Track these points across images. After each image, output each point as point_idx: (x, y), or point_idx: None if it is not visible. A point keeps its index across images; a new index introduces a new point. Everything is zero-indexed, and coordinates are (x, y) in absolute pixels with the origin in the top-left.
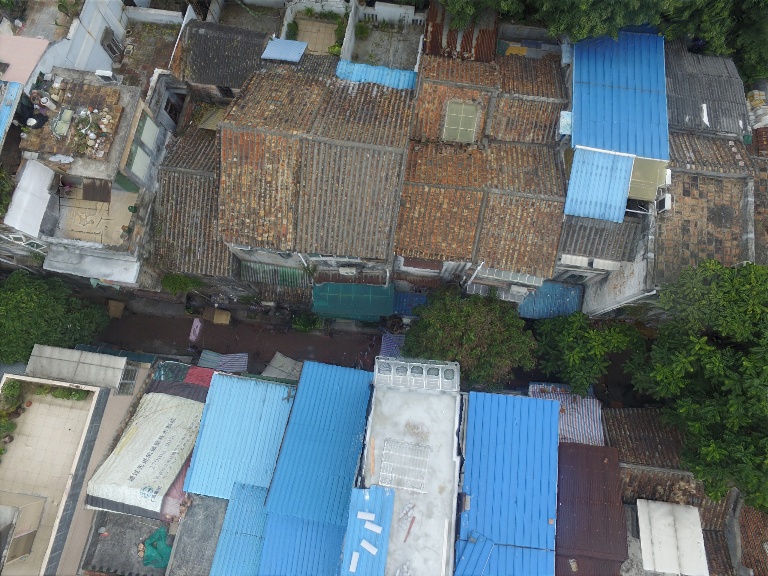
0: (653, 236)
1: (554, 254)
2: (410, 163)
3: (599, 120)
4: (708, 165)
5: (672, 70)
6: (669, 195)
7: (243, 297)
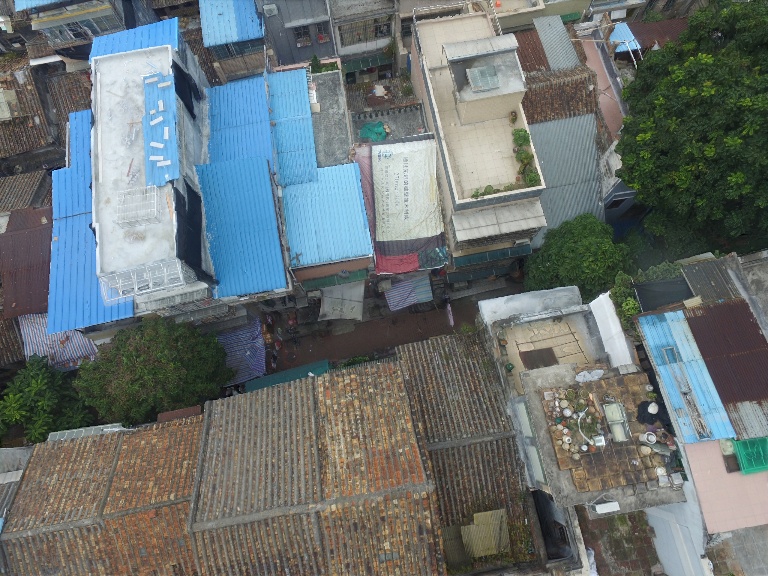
0: None
1: (29, 470)
2: None
3: None
4: None
5: None
6: None
7: None
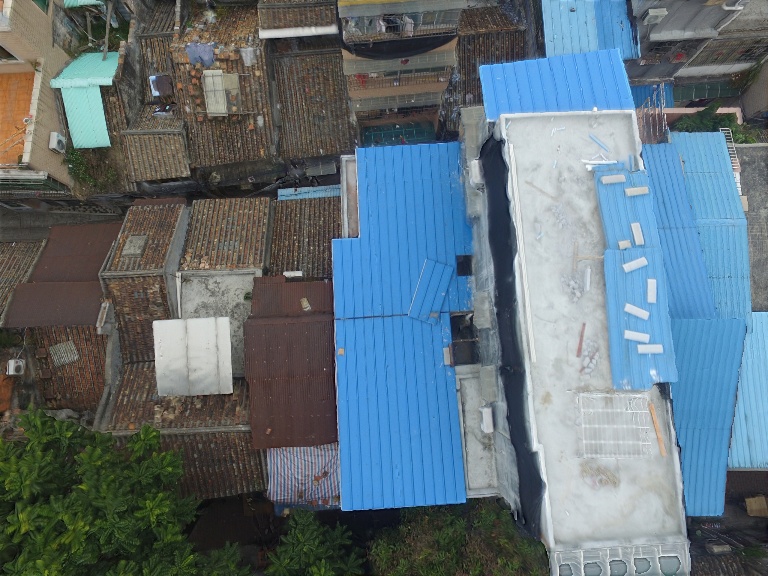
0: None
1: None
2: None
3: None
4: None
5: None
6: None
7: (762, 553)
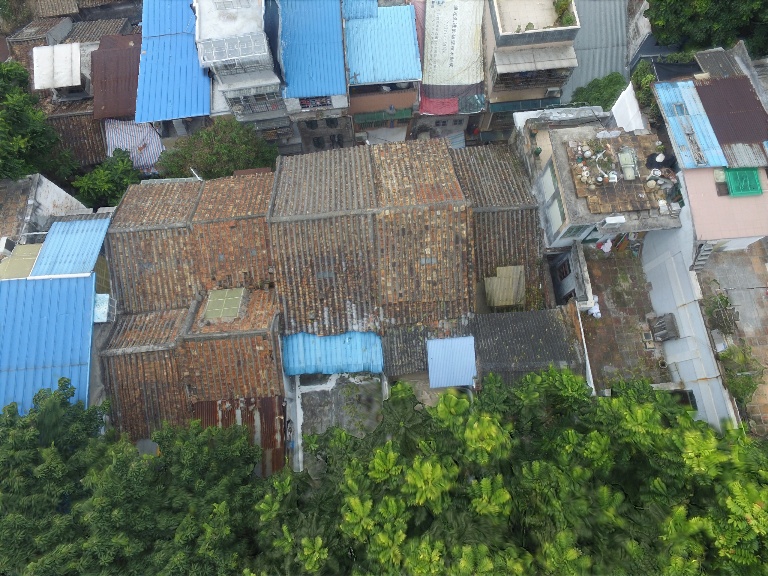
0: (26, 220)
1: (126, 198)
2: None
3: (63, 316)
4: None
5: None
6: (0, 251)
7: None
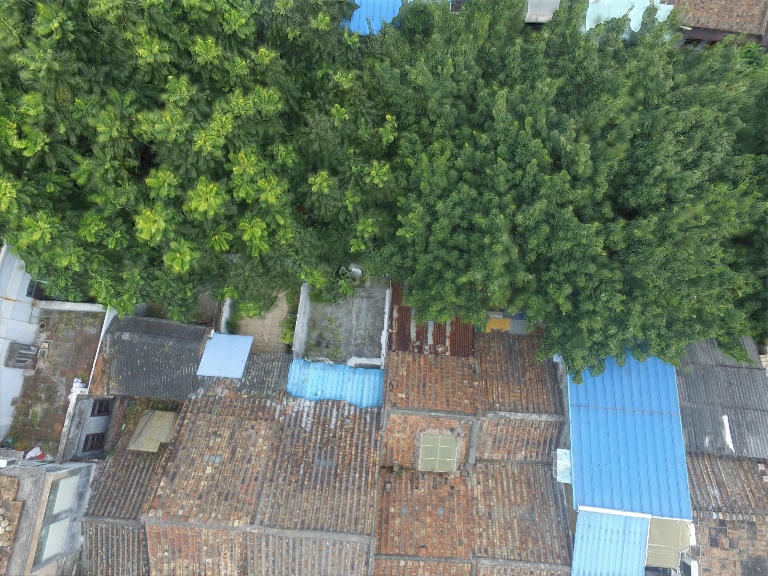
0: None
1: None
2: (381, 516)
3: (604, 462)
4: (737, 511)
5: (683, 363)
6: (695, 563)
7: None
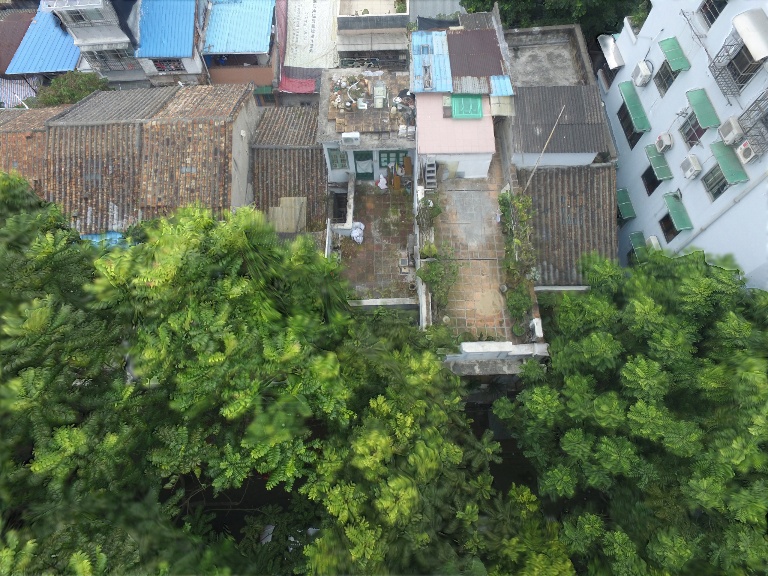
0: None
1: None
2: None
3: None
4: None
5: None
6: None
7: None
